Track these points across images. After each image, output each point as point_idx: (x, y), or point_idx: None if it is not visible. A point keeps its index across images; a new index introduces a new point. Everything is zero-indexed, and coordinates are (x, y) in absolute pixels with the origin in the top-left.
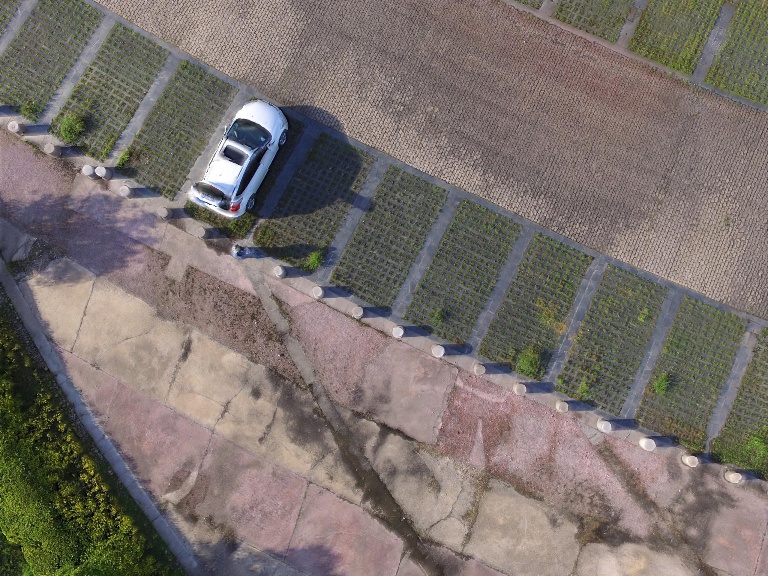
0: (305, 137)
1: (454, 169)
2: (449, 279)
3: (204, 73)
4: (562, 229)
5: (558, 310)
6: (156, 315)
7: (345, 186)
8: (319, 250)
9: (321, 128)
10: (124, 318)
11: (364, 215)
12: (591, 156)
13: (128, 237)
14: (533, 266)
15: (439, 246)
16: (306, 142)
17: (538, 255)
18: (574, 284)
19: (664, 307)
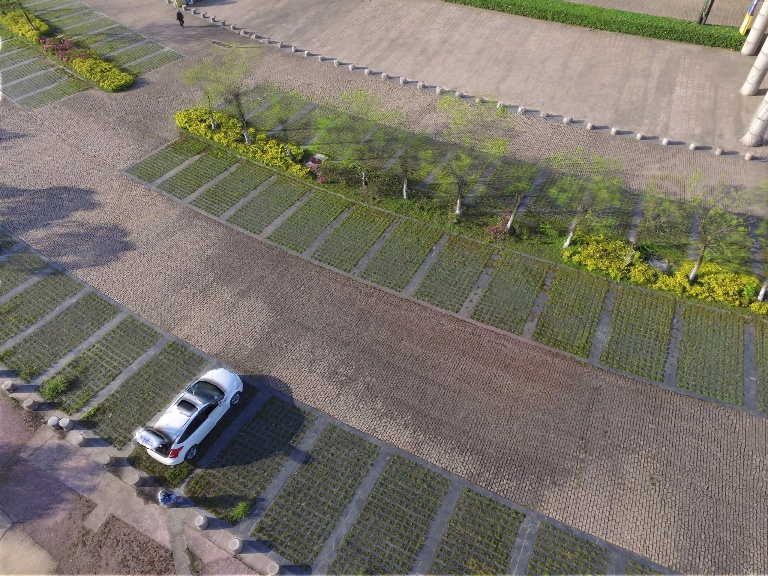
0: (256, 399)
1: (386, 428)
2: (376, 535)
3: (185, 350)
4: (490, 485)
5: (493, 574)
6: (55, 569)
7: (284, 440)
8: (246, 500)
9: (272, 392)
10: (19, 572)
11: (297, 467)
12: (511, 419)
13: (63, 484)
14: (463, 523)
15: (368, 499)
16: (256, 403)
17: (468, 511)
18: (508, 544)
19: (609, 573)
